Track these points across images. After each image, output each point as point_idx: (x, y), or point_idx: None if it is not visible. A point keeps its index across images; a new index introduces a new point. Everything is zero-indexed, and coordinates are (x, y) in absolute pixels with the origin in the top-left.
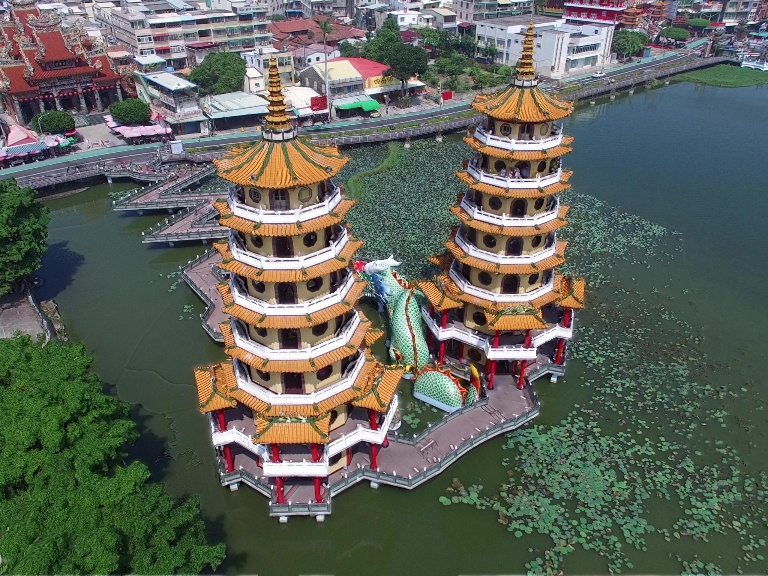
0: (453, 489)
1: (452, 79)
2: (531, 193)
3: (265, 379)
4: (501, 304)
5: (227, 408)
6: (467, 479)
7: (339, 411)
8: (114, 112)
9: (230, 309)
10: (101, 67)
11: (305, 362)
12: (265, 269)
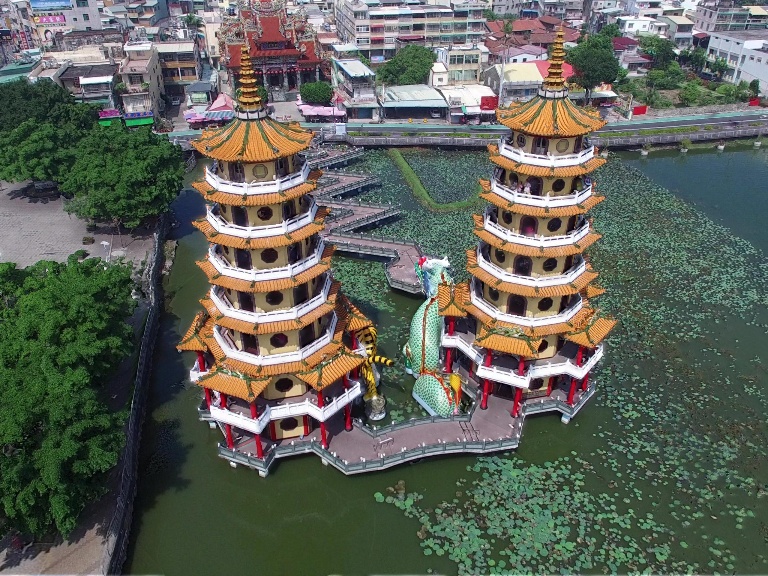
0: (394, 489)
1: (650, 93)
2: (536, 211)
3: (233, 334)
4: (501, 323)
5: (200, 351)
6: (413, 485)
7: (295, 381)
8: (302, 91)
9: (202, 263)
10: (305, 51)
11: (252, 325)
12: (221, 232)
